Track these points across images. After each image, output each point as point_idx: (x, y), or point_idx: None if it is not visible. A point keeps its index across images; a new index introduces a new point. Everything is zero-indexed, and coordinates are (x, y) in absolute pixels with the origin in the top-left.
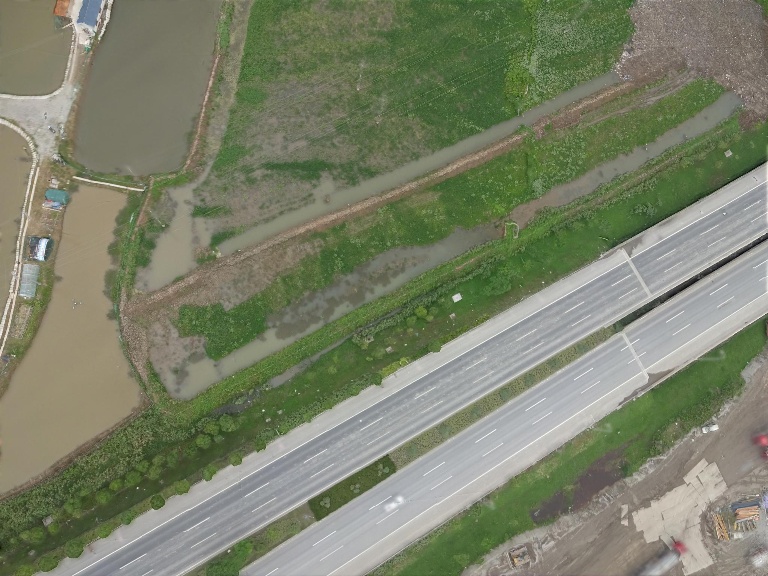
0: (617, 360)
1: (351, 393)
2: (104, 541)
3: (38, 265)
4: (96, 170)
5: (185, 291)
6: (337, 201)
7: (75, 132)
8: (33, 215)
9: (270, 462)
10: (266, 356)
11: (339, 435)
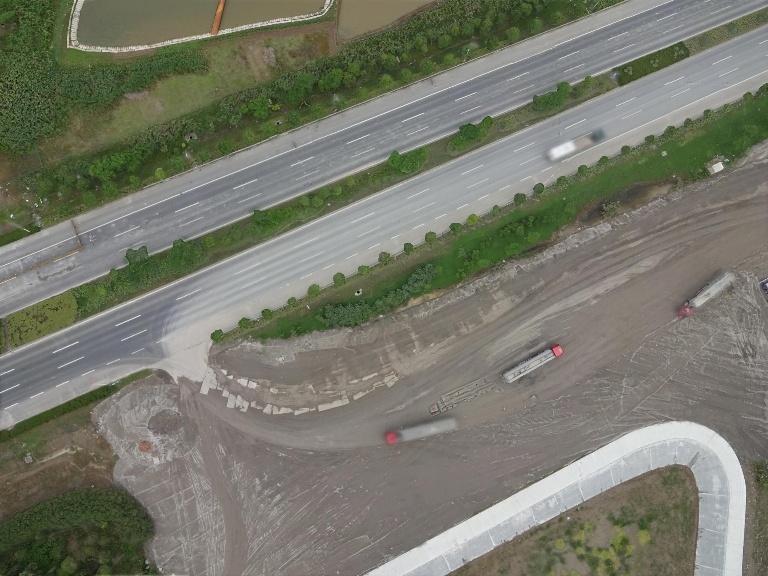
0: None
1: None
2: (443, 77)
3: None
4: None
5: None
6: None
7: None
8: None
9: (580, 35)
10: None
11: (638, 22)
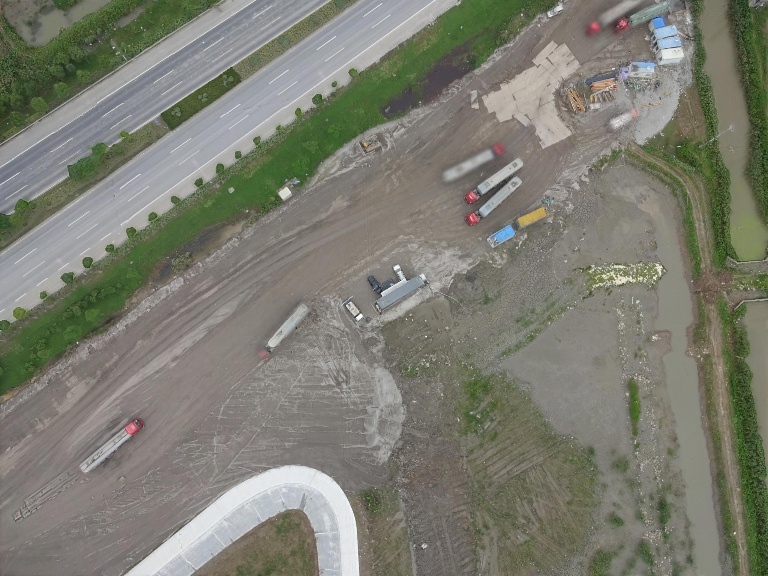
0: None
1: (183, 7)
2: None
3: None
4: None
5: None
6: None
7: None
8: None
9: (122, 86)
10: (110, 1)
11: (184, 57)
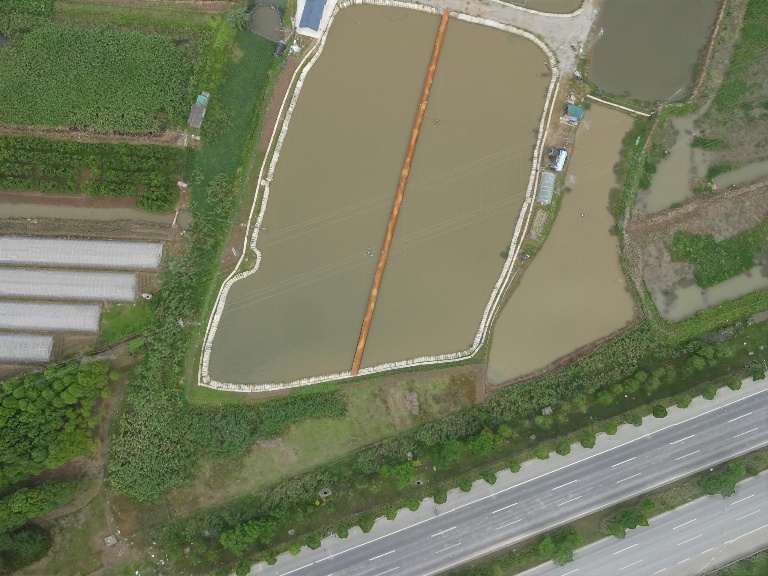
0: None
1: None
2: (600, 439)
3: (555, 175)
4: (607, 91)
5: (682, 218)
6: None
7: (591, 52)
8: (551, 127)
9: (754, 393)
10: (751, 291)
11: None
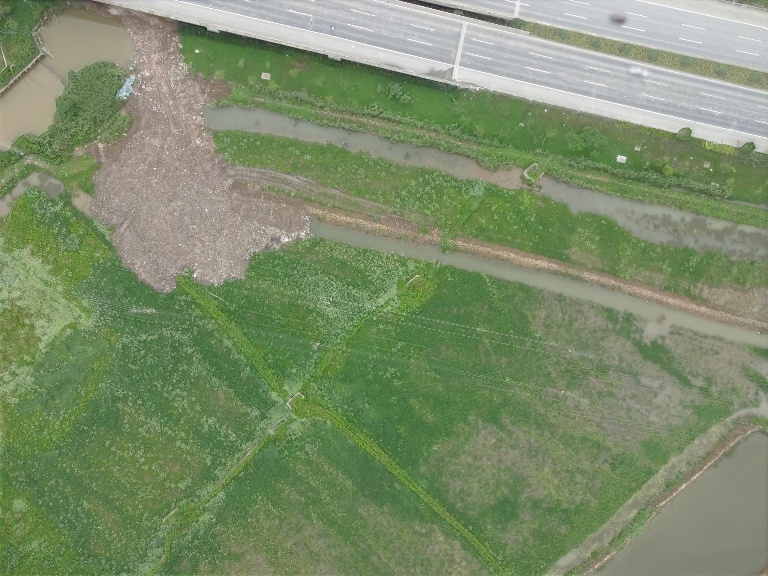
0: (539, 2)
1: None
2: None
3: None
4: None
5: None
6: (655, 312)
7: None
8: None
9: None
10: None
11: None
